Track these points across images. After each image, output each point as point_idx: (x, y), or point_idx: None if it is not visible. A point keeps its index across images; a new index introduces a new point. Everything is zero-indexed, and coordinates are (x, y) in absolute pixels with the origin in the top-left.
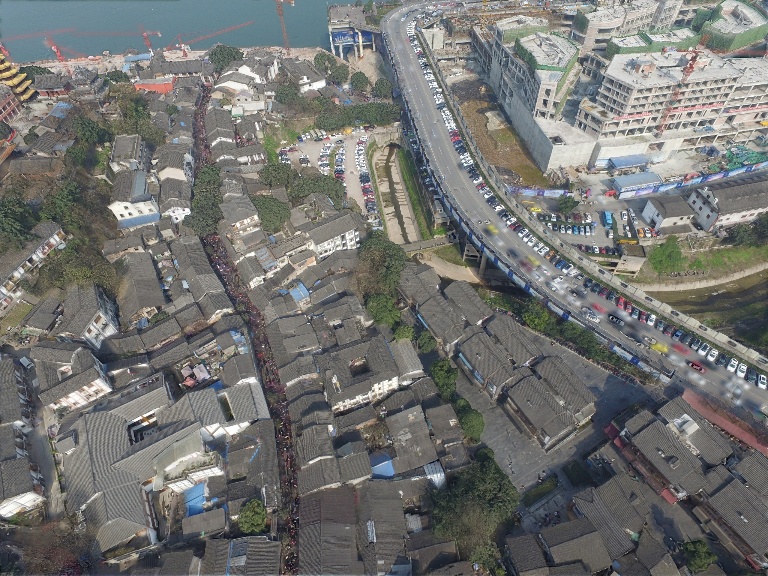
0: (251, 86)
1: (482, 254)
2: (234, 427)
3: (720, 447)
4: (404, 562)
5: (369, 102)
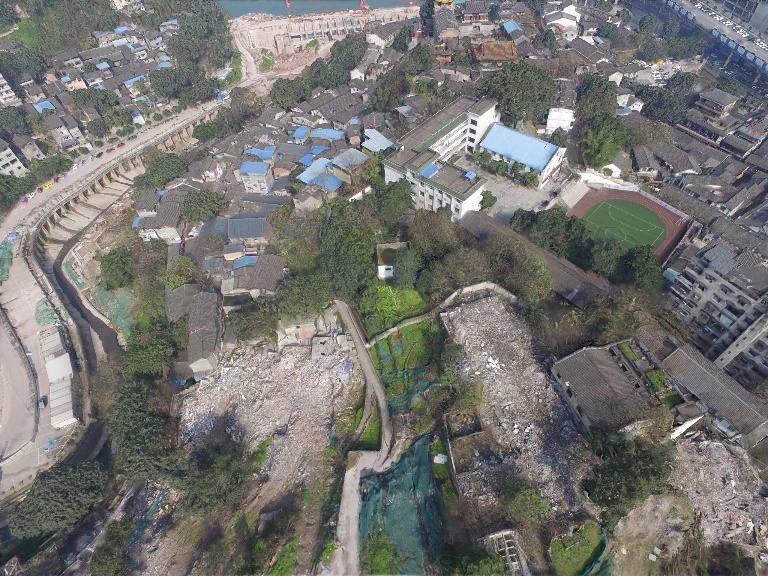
0: (577, 23)
1: None
2: None
3: None
4: None
5: None
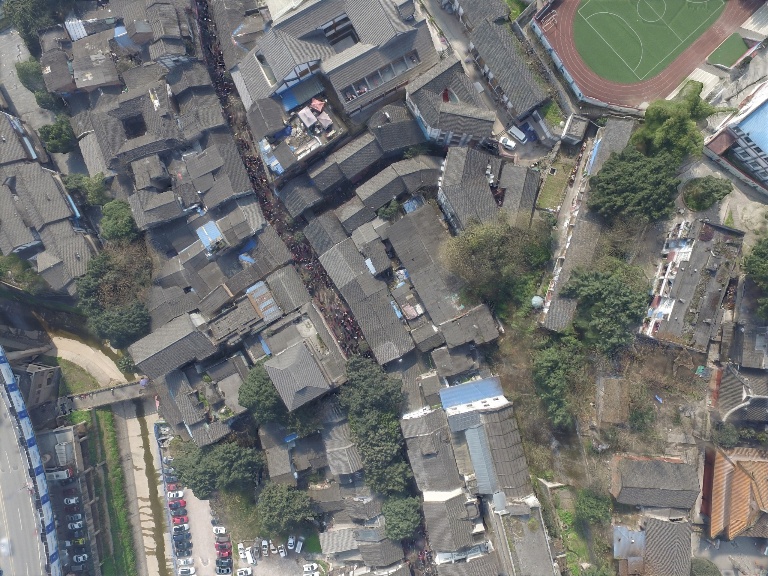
0: None
1: None
2: None
3: None
4: None
5: None
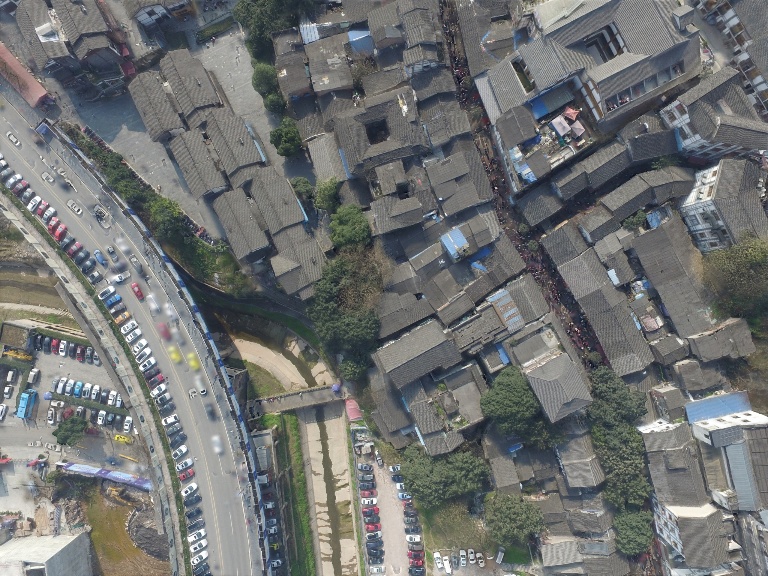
0: None
1: None
2: None
3: (25, 8)
4: None
5: None
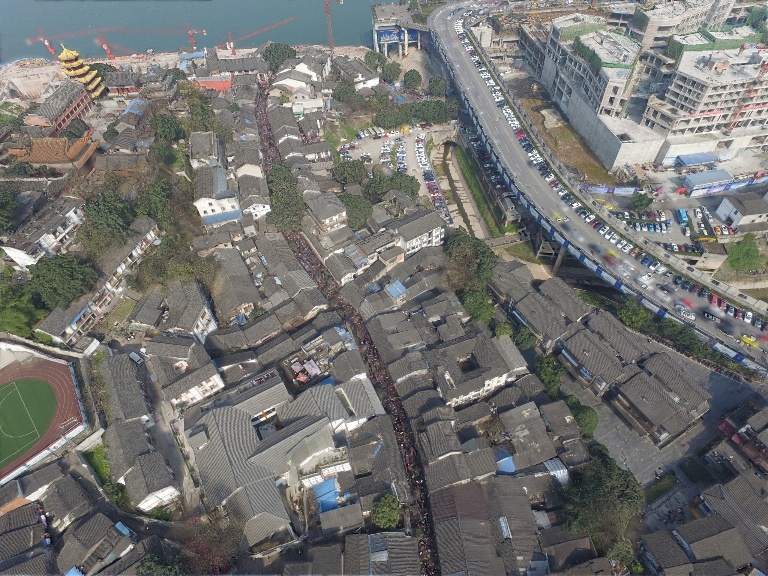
0: (308, 84)
1: (558, 251)
2: (354, 423)
3: None
4: (541, 558)
5: (422, 100)
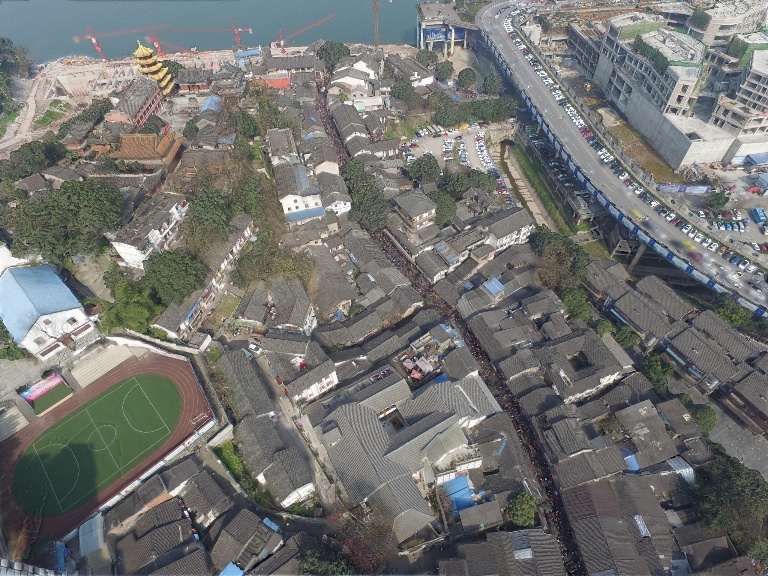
0: (367, 82)
1: (635, 250)
2: (476, 420)
3: None
4: (680, 557)
5: (476, 98)
